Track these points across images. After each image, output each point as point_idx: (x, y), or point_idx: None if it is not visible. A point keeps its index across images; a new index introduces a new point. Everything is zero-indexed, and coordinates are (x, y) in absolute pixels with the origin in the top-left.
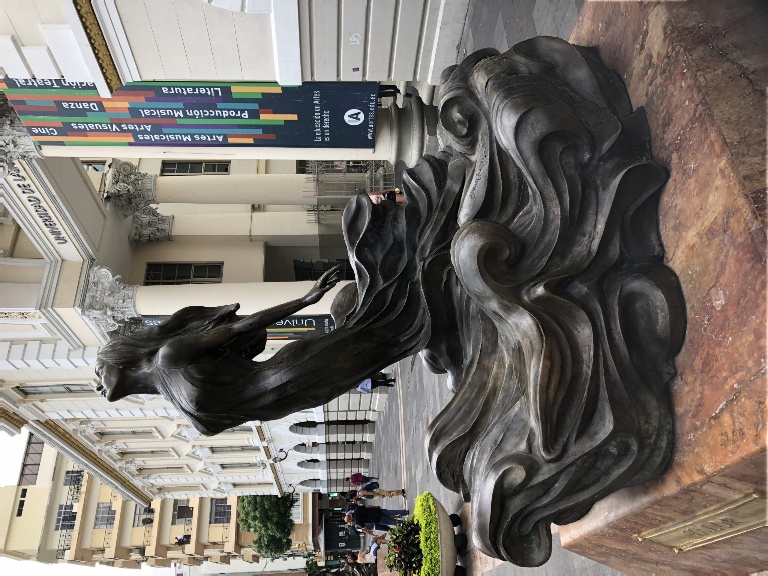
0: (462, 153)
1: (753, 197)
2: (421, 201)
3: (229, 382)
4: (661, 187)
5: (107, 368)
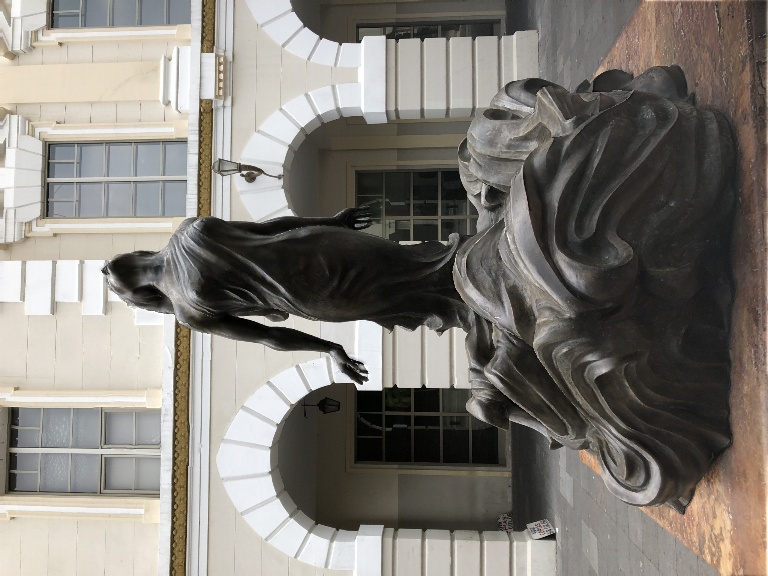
0: None
1: None
2: None
3: None
4: None
5: None
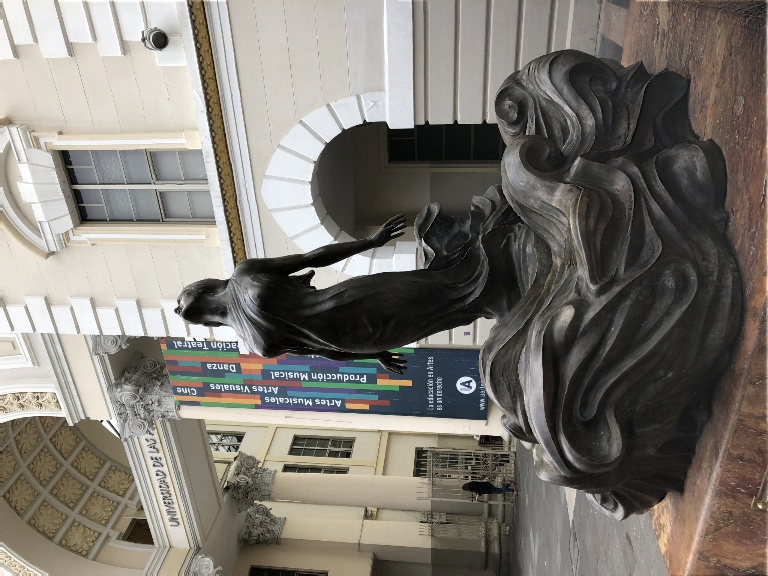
0: None
1: (744, 12)
2: (486, 209)
3: (291, 290)
4: (686, 95)
5: (189, 291)
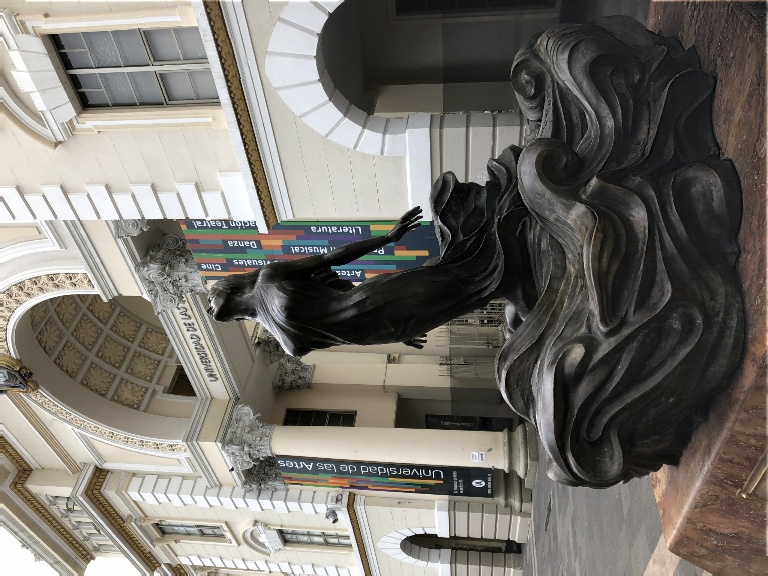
0: (535, 122)
1: None
2: (502, 178)
3: (316, 297)
4: (711, 95)
5: (218, 292)
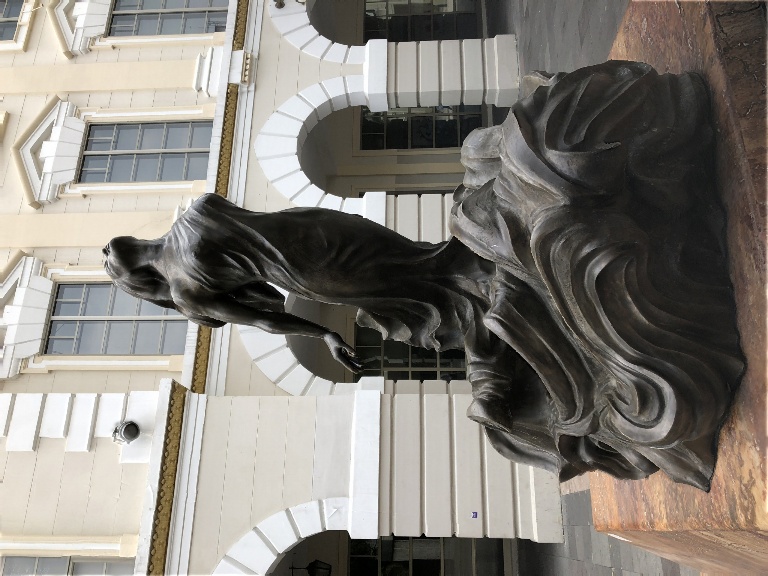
0: None
1: None
2: None
3: None
4: None
5: None
